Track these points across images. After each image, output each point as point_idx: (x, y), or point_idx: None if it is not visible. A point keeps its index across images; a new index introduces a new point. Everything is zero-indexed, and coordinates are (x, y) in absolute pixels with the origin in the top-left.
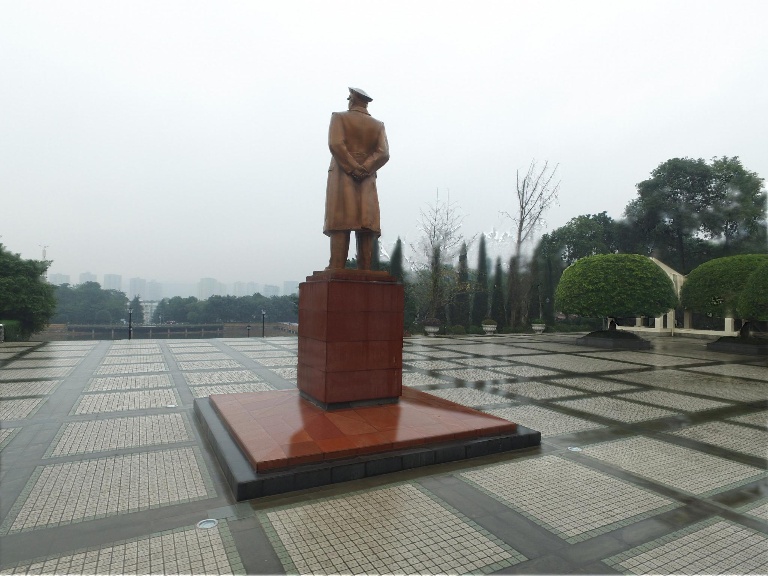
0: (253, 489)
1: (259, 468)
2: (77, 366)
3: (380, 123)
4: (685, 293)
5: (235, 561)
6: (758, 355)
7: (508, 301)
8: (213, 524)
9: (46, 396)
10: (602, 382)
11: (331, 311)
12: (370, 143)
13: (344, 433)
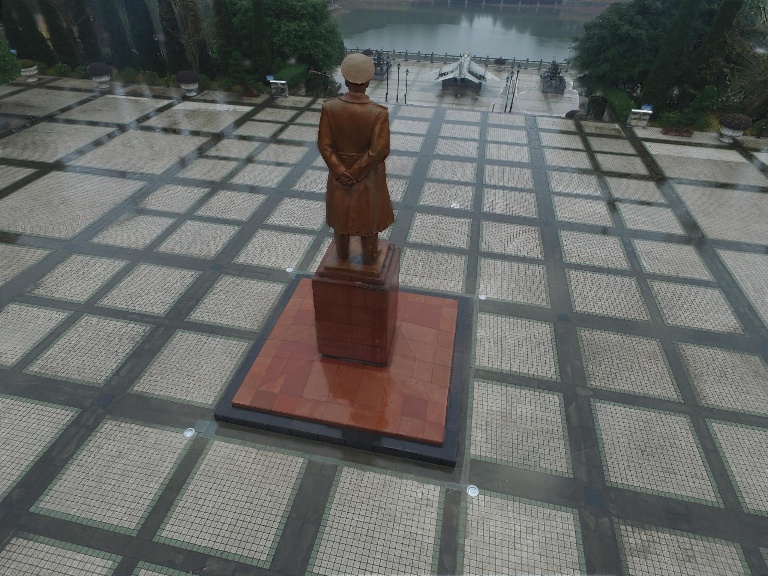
0: (222, 418)
1: (233, 405)
2: (294, 167)
3: (376, 114)
4: None
5: (172, 472)
6: None
7: None
8: None
9: (242, 224)
10: (759, 380)
11: (316, 301)
12: (362, 142)
13: (303, 393)
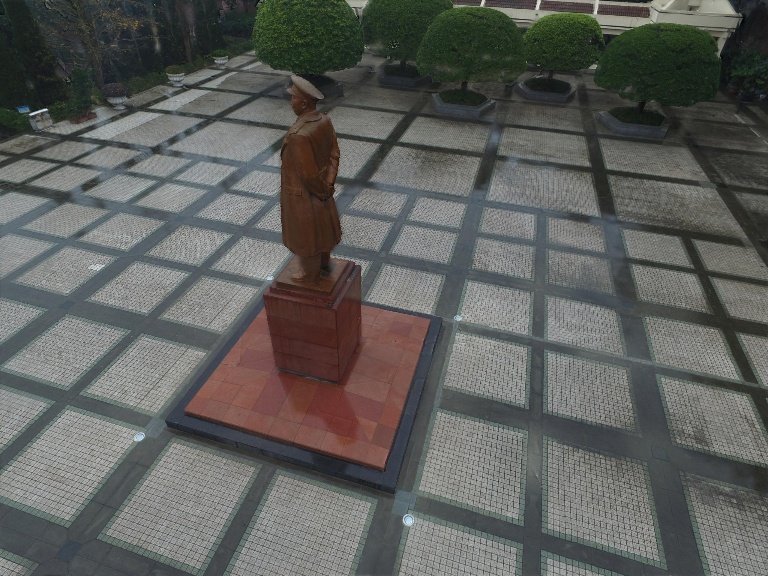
0: None
1: None
2: None
3: None
4: (367, 31)
5: (456, 527)
6: (415, 88)
7: (172, 23)
8: (409, 517)
9: None
10: (382, 195)
11: (338, 328)
12: None
13: (380, 402)
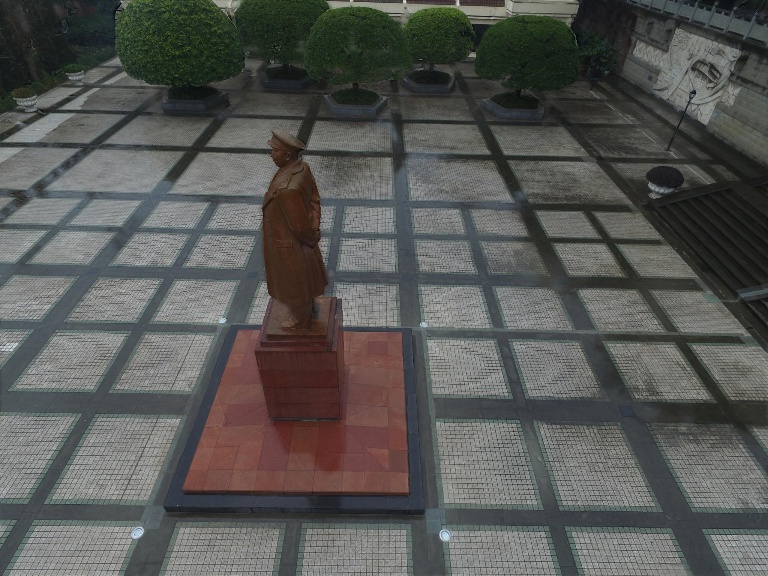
0: None
1: (409, 493)
2: None
3: None
4: (244, 36)
5: (488, 528)
6: (303, 90)
7: None
8: (445, 532)
9: None
10: None
11: None
12: None
13: (384, 427)
